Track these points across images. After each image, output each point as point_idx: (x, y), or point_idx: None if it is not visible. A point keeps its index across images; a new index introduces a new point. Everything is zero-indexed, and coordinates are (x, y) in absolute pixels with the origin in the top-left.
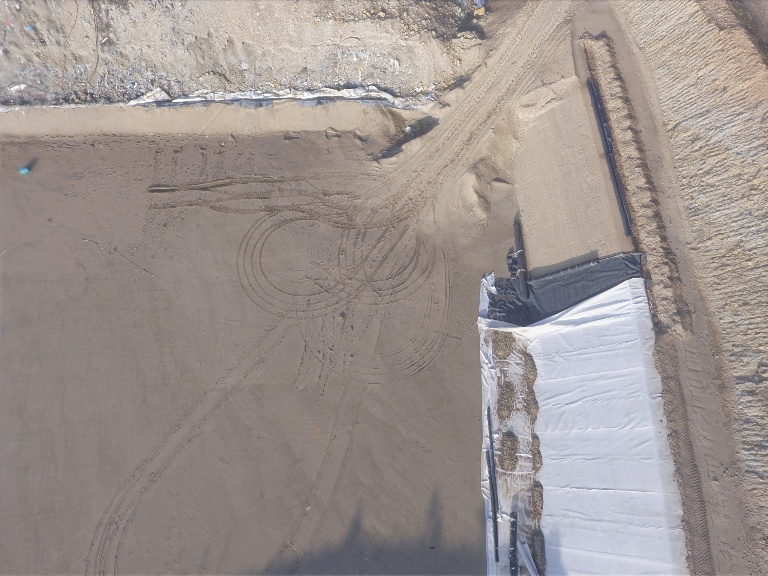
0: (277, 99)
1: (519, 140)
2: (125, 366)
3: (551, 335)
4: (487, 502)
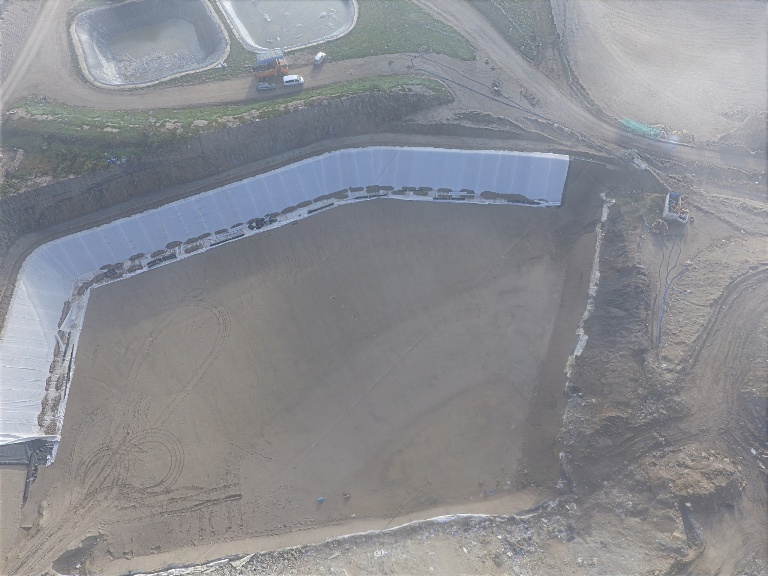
0: (158, 571)
1: (5, 557)
2: (232, 395)
3: (25, 433)
4: (73, 363)
